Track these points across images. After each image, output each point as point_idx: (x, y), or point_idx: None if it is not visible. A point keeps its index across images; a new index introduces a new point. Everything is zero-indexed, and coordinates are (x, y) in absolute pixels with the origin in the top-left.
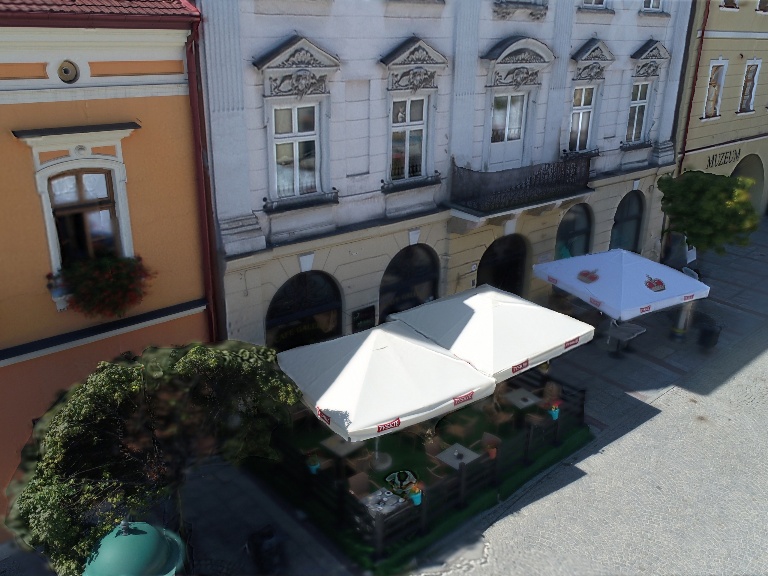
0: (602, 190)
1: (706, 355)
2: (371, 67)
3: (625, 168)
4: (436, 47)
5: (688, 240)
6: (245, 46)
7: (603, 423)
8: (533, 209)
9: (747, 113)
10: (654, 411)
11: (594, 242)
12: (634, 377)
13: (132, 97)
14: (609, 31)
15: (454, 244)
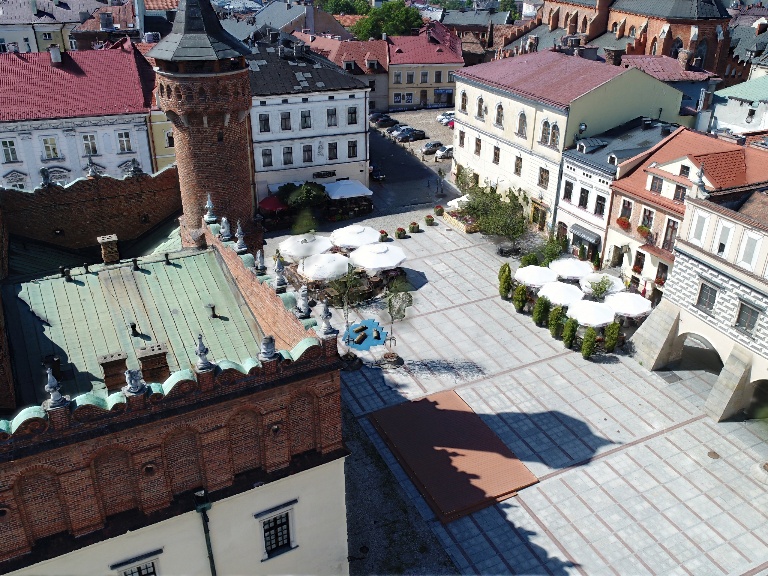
0: None
1: None
2: (1, 178)
3: None
4: (23, 172)
5: None
6: None
7: None
8: None
9: None
10: None
11: None
12: None
13: None
14: (102, 161)
15: None
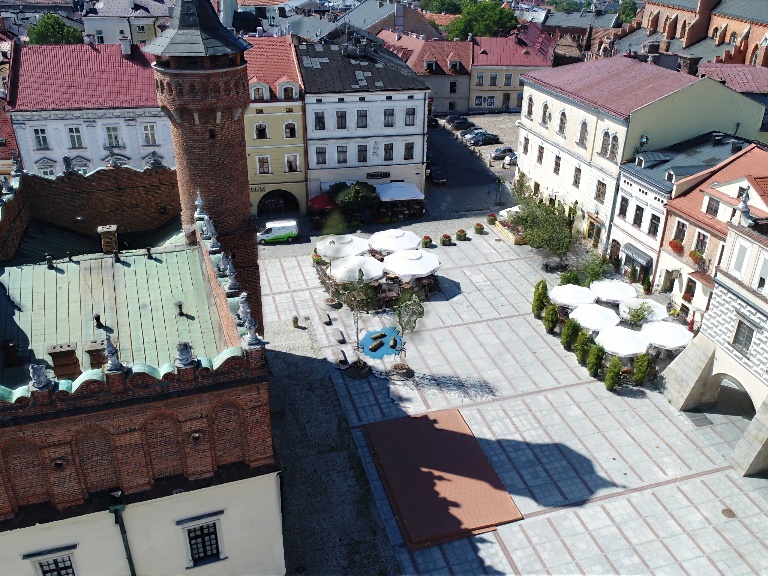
0: None
1: None
2: None
3: None
4: (87, 158)
5: None
6: (33, 160)
7: None
8: None
9: (266, 174)
10: None
11: None
12: None
13: (9, 169)
14: (161, 151)
15: None
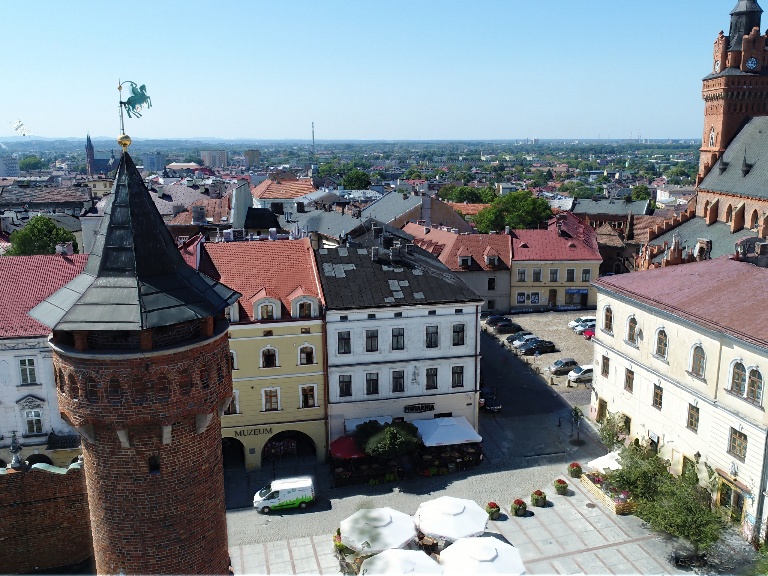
0: None
1: None
2: (14, 403)
3: None
4: (40, 397)
5: None
6: None
7: None
8: (76, 449)
9: (273, 411)
10: None
11: None
12: None
13: None
14: None
15: (55, 455)
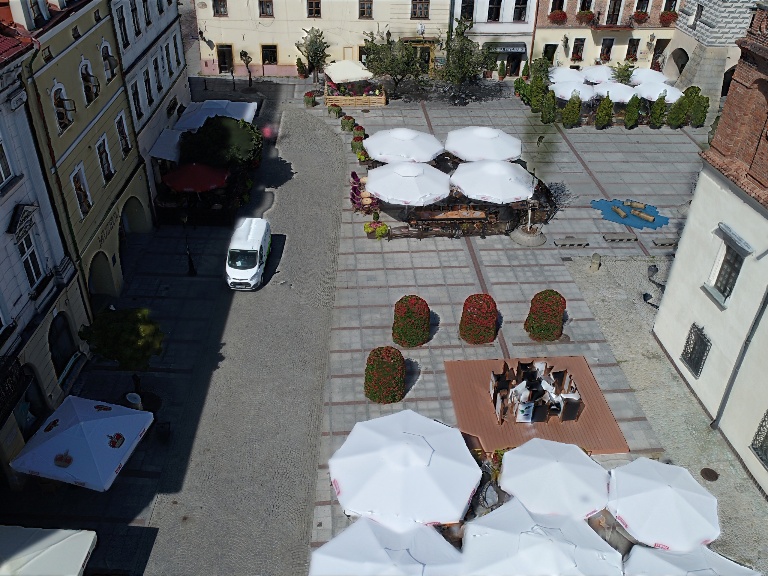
0: (31, 343)
1: (167, 444)
2: None
3: (41, 310)
4: None
5: (120, 367)
6: None
7: (126, 570)
8: None
9: (111, 179)
10: (154, 532)
11: (42, 380)
12: (128, 503)
13: None
14: None
15: None
